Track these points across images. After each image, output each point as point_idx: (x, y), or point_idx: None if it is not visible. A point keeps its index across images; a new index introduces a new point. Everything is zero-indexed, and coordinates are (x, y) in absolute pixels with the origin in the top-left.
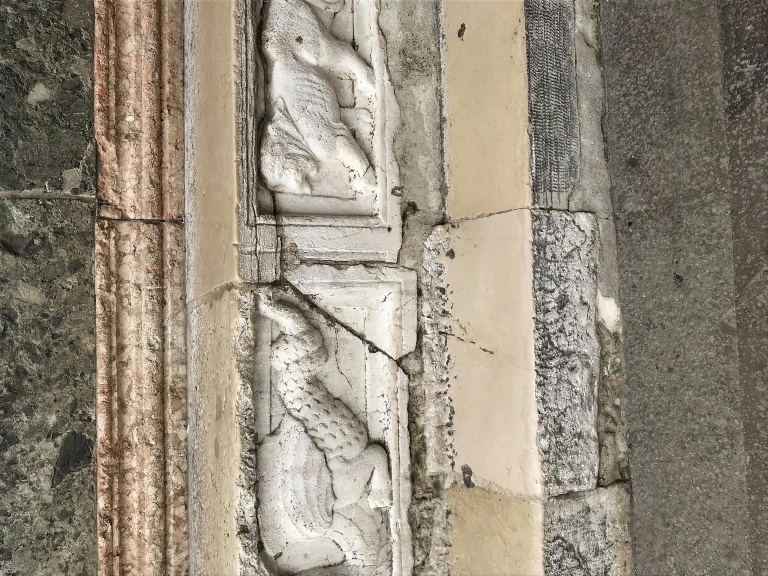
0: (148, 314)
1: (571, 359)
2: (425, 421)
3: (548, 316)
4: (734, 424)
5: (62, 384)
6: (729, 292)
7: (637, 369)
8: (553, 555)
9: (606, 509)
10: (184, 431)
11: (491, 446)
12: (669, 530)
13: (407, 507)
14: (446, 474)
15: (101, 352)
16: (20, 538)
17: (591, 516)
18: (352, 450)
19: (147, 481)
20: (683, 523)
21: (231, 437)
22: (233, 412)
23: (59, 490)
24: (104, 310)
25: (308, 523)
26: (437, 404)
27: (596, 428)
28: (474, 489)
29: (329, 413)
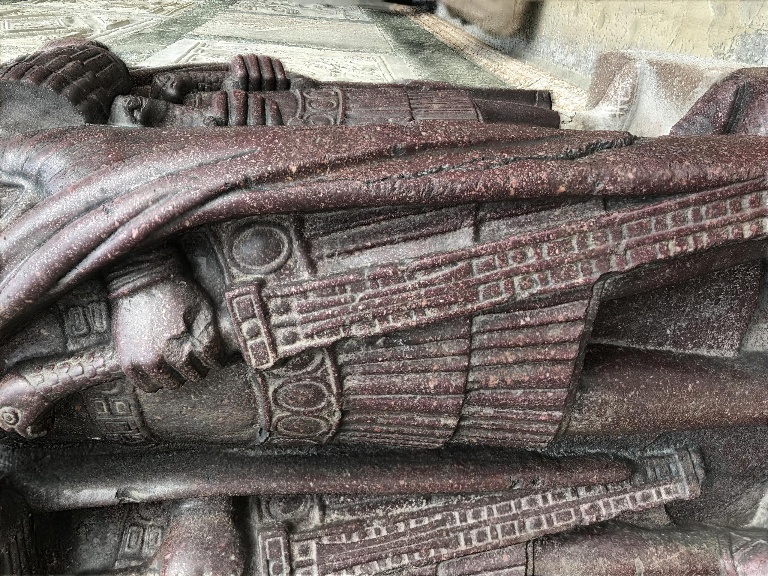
0: None
1: None
2: None
3: None
4: None
5: None
6: None
7: None
8: None
9: None
10: None
11: None
12: None
13: None
14: None
15: None
16: None
17: None
18: None
19: (512, 67)
20: None
21: None
22: None
23: None
24: None
25: None
26: None
27: None
28: None
29: None
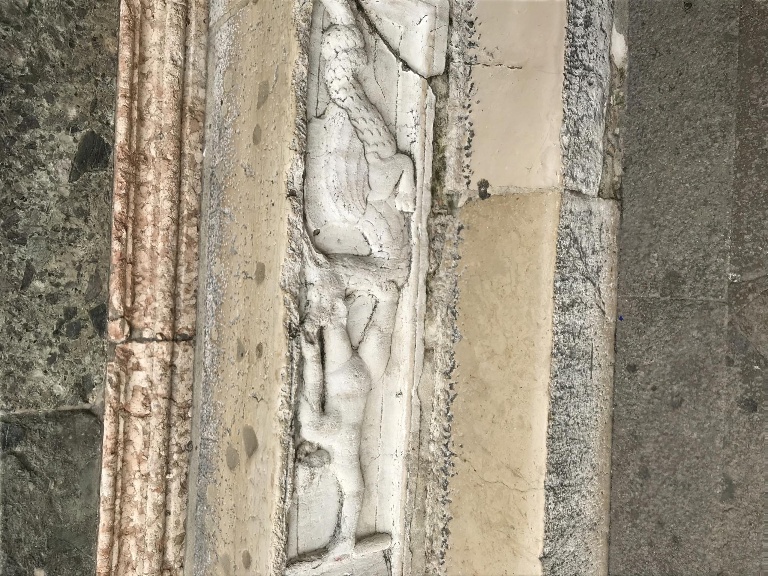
0: (172, 28)
1: (590, 75)
2: (446, 142)
3: (577, 30)
4: (728, 118)
5: (83, 79)
6: (735, 5)
7: (639, 97)
8: (564, 240)
9: (603, 217)
10: (200, 154)
11: (512, 153)
12: (655, 231)
13: (427, 215)
14: (460, 194)
15: (125, 55)
16: (35, 226)
17: (592, 219)
18: (385, 151)
19: (163, 195)
20: (669, 220)
21: (285, 106)
22: (289, 81)
23: (76, 186)
24: (130, 13)
25: (347, 204)
26: (458, 127)
27: (602, 143)
28: (490, 198)
29: (368, 111)
